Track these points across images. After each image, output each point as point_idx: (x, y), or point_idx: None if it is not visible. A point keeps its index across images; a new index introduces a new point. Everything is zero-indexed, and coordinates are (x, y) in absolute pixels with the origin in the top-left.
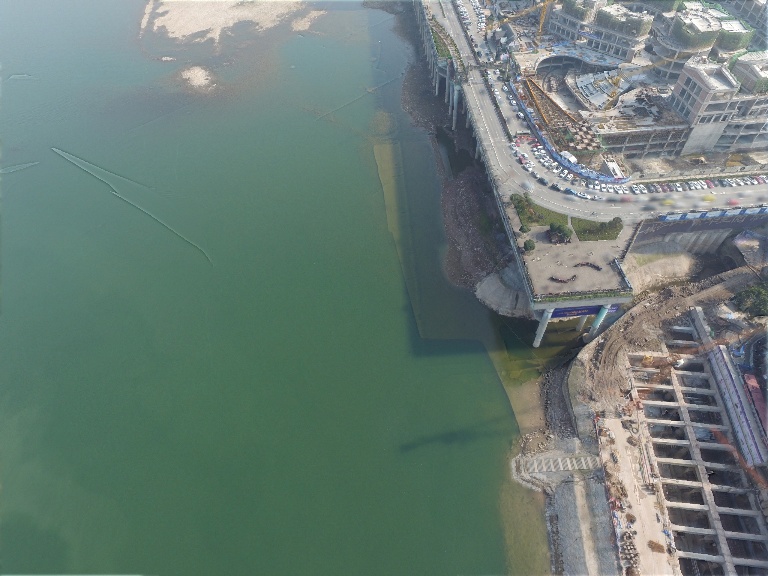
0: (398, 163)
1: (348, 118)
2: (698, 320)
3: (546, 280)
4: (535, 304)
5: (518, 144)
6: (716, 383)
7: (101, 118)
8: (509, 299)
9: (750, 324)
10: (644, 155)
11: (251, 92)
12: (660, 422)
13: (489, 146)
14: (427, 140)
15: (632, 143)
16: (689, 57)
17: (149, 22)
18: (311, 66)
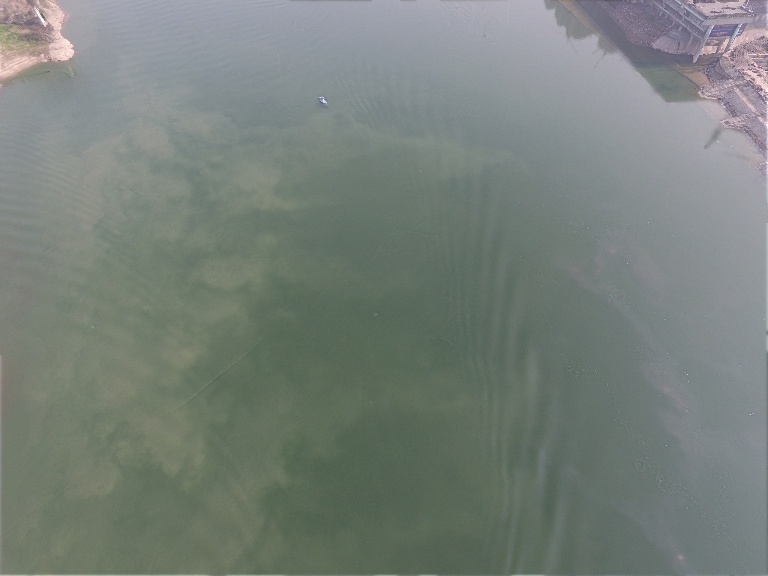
0: (575, 3)
1: None
2: None
3: (709, 13)
4: (707, 20)
5: None
6: None
7: None
8: (674, 45)
9: None
10: None
11: None
12: None
13: None
14: None
15: None
16: None
17: None
18: None
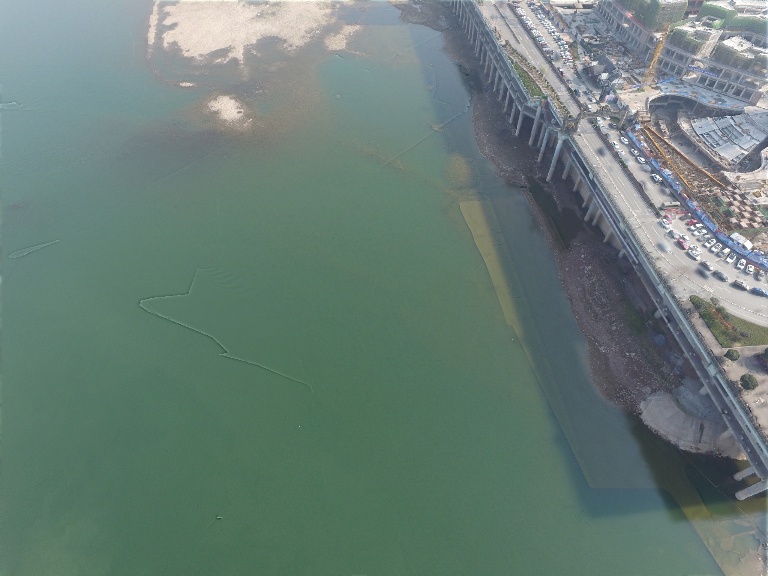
0: (495, 227)
1: (419, 165)
2: None
3: None
4: None
5: (670, 220)
6: None
7: (119, 164)
8: (691, 430)
9: None
10: None
11: (296, 130)
12: None
13: (634, 223)
14: (521, 195)
15: None
16: None
17: (157, 37)
18: (358, 95)
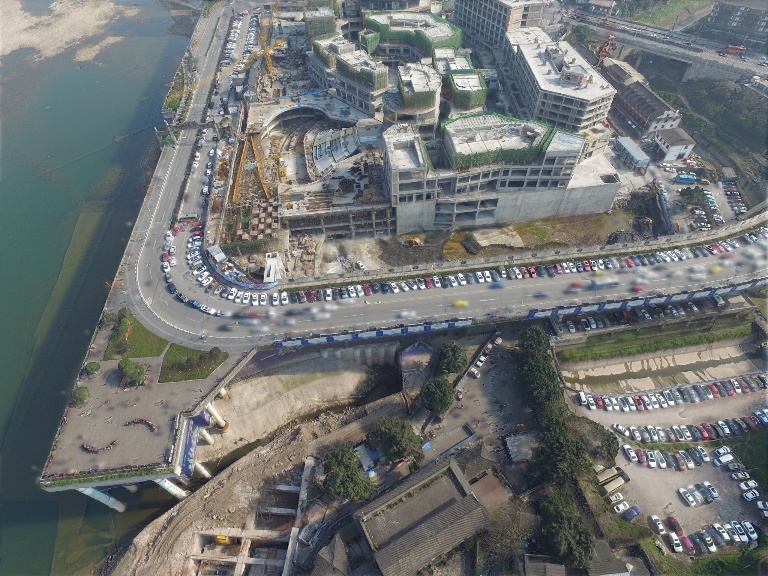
0: (95, 238)
1: (73, 176)
2: None
3: (76, 449)
4: None
5: (175, 233)
6: None
7: None
8: None
9: None
10: (354, 235)
11: None
12: None
13: (141, 235)
14: None
15: (331, 224)
16: (413, 118)
17: None
18: (71, 106)
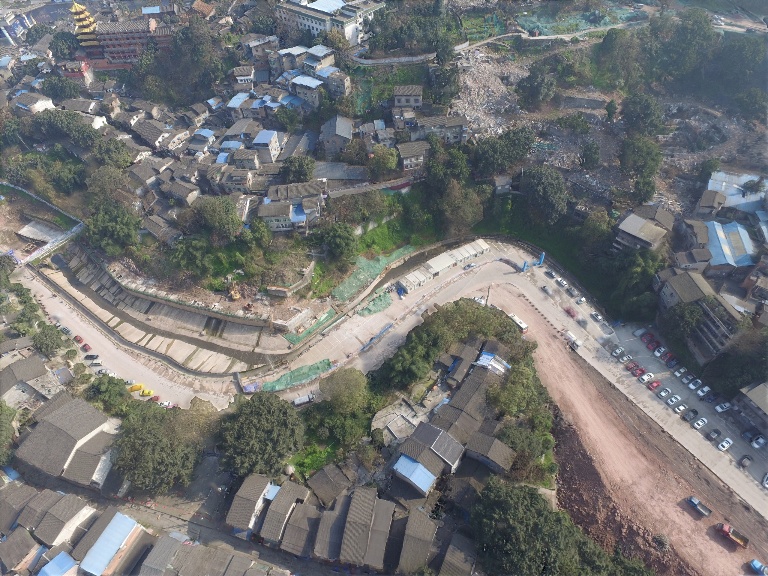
0: None
1: None
2: None
3: None
4: None
5: None
6: None
7: None
8: None
9: None
10: None
11: None
12: None
13: None
14: None
15: None
16: None
17: None
18: None
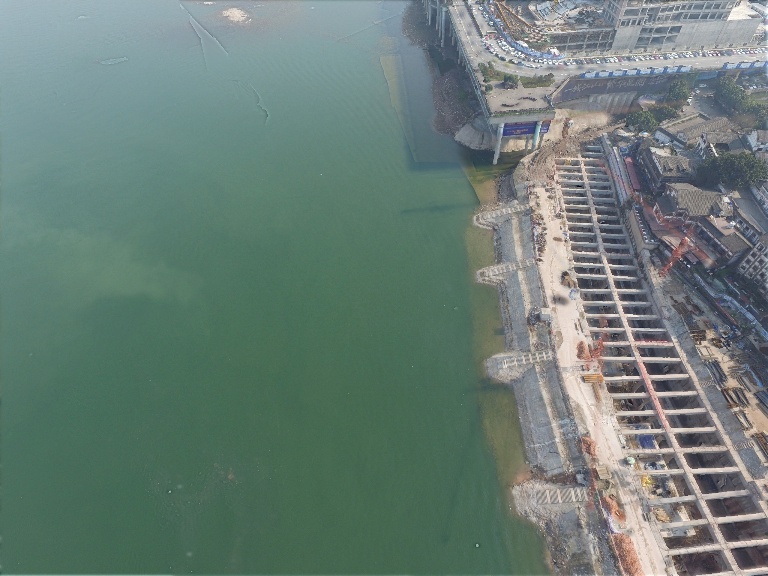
0: (399, 67)
1: (359, 41)
2: (604, 140)
3: (499, 106)
4: (490, 118)
5: (487, 39)
6: (610, 171)
7: (162, 42)
8: (477, 138)
9: (636, 138)
10: None
11: (280, 24)
12: (570, 189)
13: (466, 41)
14: (421, 53)
15: (573, 43)
16: None
17: None
18: (328, 8)
